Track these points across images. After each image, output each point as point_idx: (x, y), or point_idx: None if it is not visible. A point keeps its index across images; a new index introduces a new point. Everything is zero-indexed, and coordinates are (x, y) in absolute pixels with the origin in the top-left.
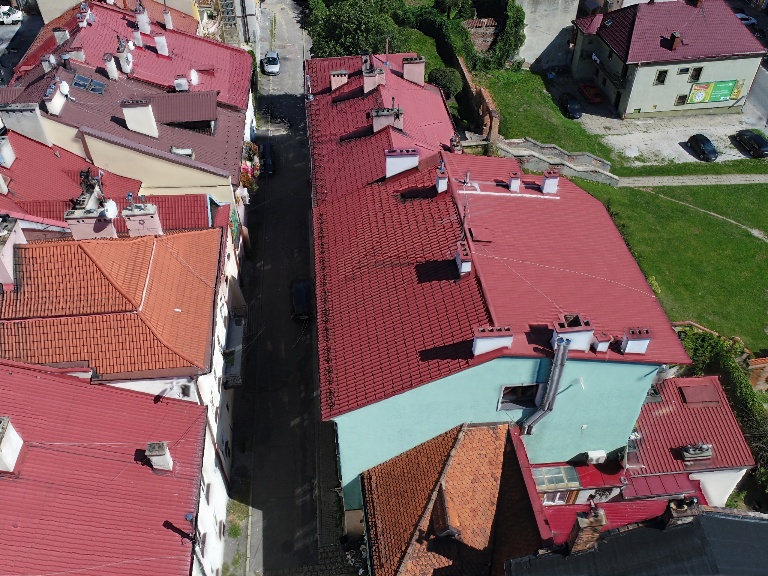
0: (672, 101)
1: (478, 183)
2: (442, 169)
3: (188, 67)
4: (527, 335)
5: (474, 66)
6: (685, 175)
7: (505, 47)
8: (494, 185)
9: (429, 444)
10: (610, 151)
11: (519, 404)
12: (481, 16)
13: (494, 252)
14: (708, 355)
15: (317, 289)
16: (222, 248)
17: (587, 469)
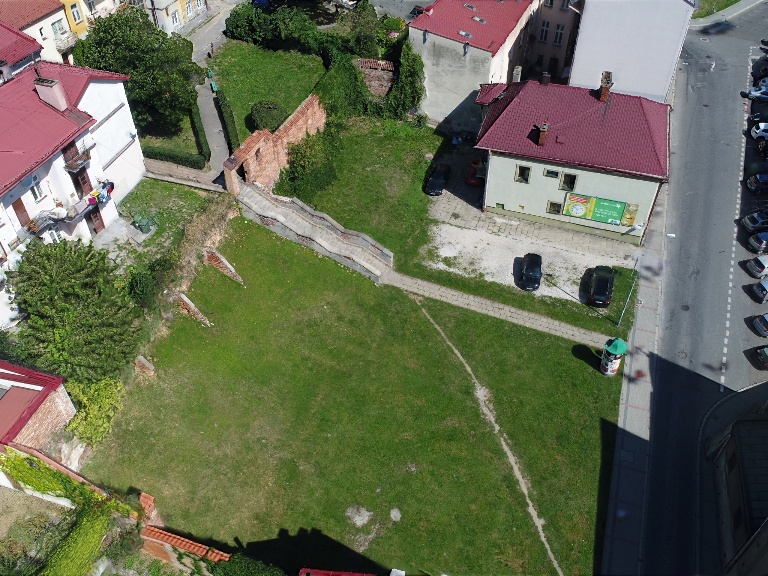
0: (543, 206)
1: None
2: None
3: None
4: None
5: (365, 109)
6: (479, 296)
7: (400, 97)
8: None
9: None
10: (426, 242)
11: None
12: (379, 57)
13: None
14: (80, 499)
15: None
16: None
17: None
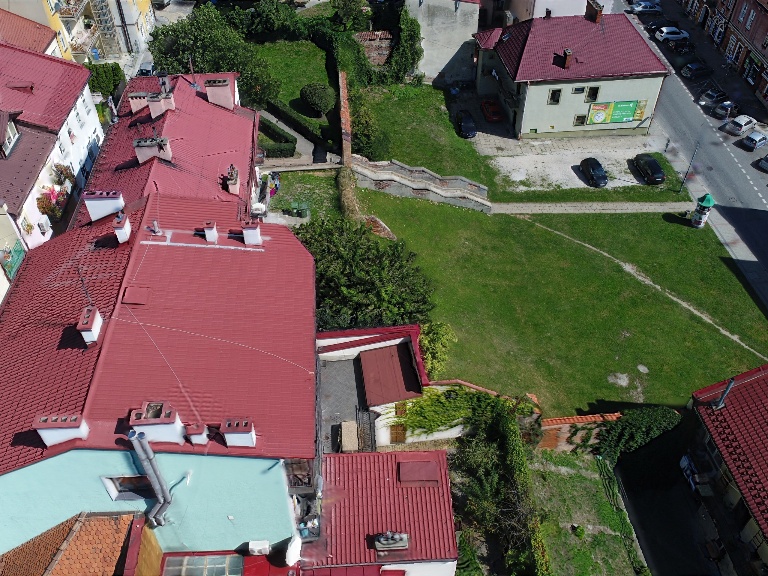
0: (570, 121)
1: (173, 232)
2: (121, 218)
3: (4, 84)
4: (119, 422)
5: (369, 80)
6: (569, 202)
7: (401, 61)
8: (191, 234)
9: (51, 532)
10: (496, 174)
11: (139, 494)
12: (375, 28)
13: (141, 317)
14: (489, 415)
15: None
16: None
17: (256, 559)
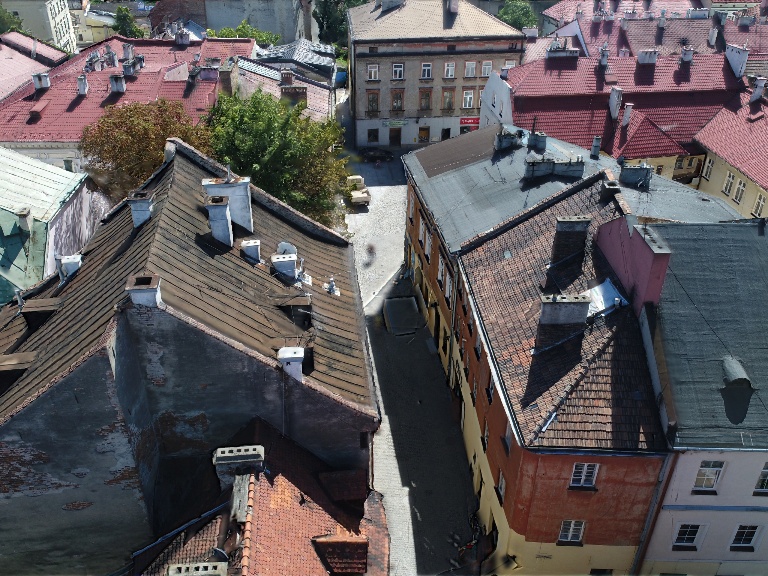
0: None
1: None
2: None
3: None
4: None
5: None
6: None
7: None
8: None
9: None
10: None
11: None
12: None
13: None
14: None
15: (754, 1)
16: None
17: None
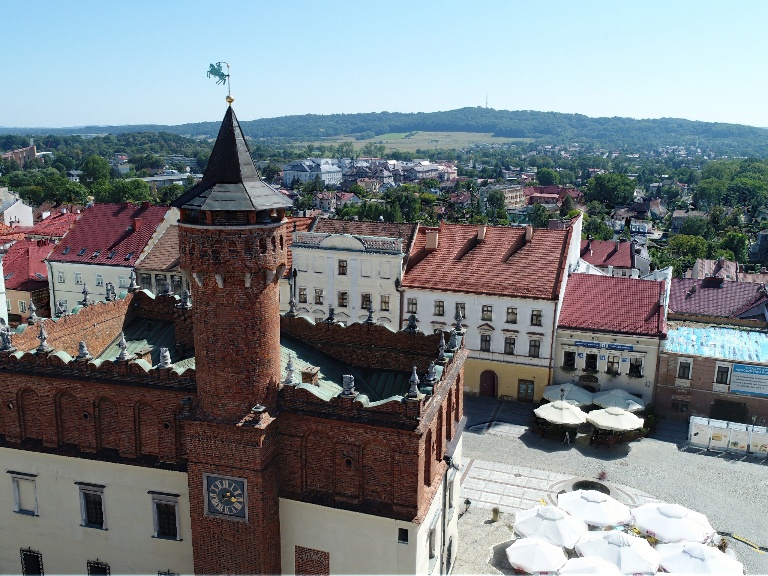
0: None
1: None
2: None
3: None
4: None
5: None
6: None
7: None
8: None
9: None
10: None
11: None
12: None
13: None
14: None
15: None
16: None
17: None
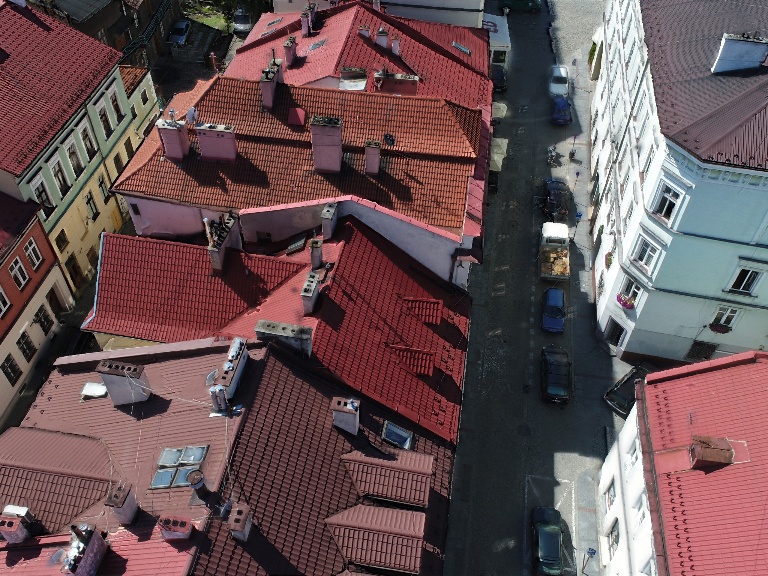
0: None
1: None
2: None
3: None
4: None
5: None
6: None
7: None
8: None
9: None
10: None
11: None
12: None
13: None
14: None
15: None
16: (122, 171)
17: None
